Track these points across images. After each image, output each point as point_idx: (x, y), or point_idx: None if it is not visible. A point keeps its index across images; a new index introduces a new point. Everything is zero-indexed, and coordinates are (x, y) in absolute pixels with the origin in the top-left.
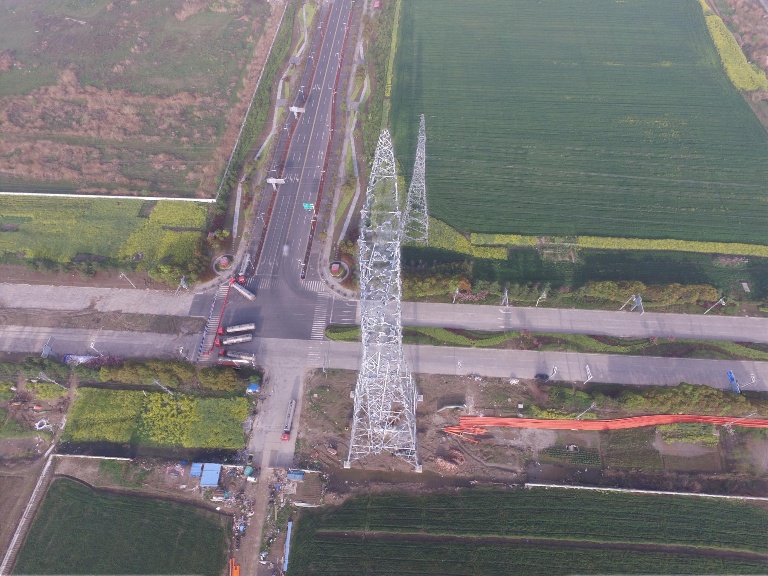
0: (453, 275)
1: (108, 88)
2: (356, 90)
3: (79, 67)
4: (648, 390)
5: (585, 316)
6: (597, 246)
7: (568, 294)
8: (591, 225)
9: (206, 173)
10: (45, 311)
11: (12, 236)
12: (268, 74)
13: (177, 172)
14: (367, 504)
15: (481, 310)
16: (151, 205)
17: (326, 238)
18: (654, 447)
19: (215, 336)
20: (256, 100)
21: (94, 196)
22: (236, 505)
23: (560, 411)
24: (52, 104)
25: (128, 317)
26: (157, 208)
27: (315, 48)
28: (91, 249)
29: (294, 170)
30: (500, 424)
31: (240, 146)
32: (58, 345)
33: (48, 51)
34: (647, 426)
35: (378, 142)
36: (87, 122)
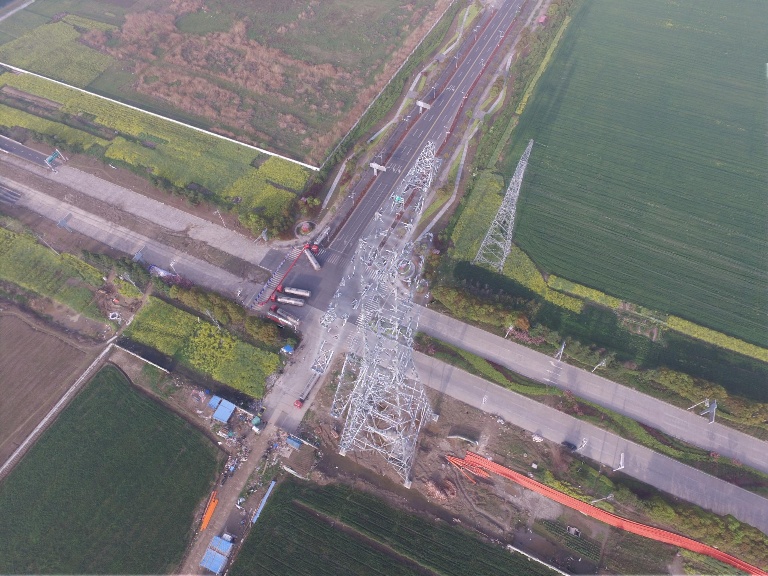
0: (515, 310)
1: (267, 45)
2: (488, 100)
3: (251, 21)
4: (684, 506)
5: (644, 401)
6: (688, 332)
7: (633, 372)
8: (690, 308)
9: (320, 142)
10: (150, 223)
11: (149, 152)
12: (410, 65)
13: (297, 135)
14: (347, 496)
15: (531, 355)
16: (264, 158)
17: (405, 234)
18: (668, 570)
19: (274, 291)
20: (389, 86)
21: (222, 137)
22: (235, 446)
23: (575, 488)
24: (218, 49)
25: (210, 250)
26: (268, 162)
27: (464, 50)
28: (203, 182)
29: (400, 161)
30: (506, 475)
31: (359, 126)
32: (149, 255)
33: (232, 2)
34: (669, 544)
35: (422, 152)
36: (240, 71)
